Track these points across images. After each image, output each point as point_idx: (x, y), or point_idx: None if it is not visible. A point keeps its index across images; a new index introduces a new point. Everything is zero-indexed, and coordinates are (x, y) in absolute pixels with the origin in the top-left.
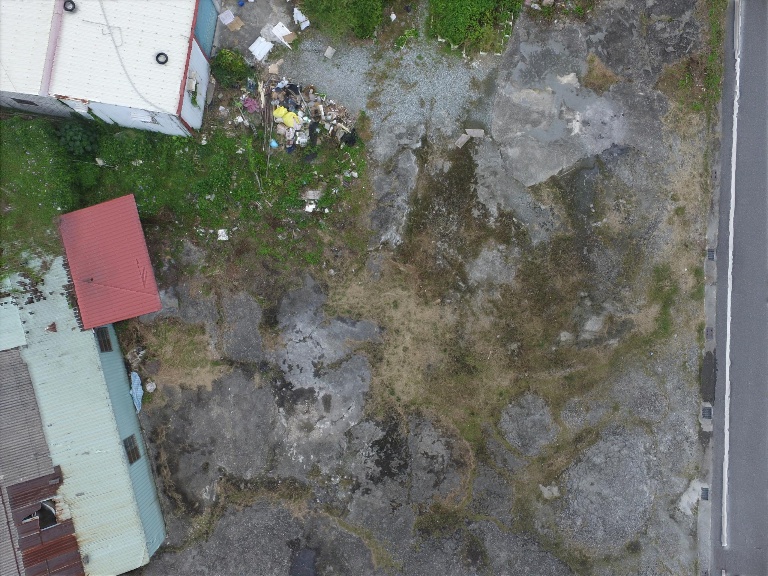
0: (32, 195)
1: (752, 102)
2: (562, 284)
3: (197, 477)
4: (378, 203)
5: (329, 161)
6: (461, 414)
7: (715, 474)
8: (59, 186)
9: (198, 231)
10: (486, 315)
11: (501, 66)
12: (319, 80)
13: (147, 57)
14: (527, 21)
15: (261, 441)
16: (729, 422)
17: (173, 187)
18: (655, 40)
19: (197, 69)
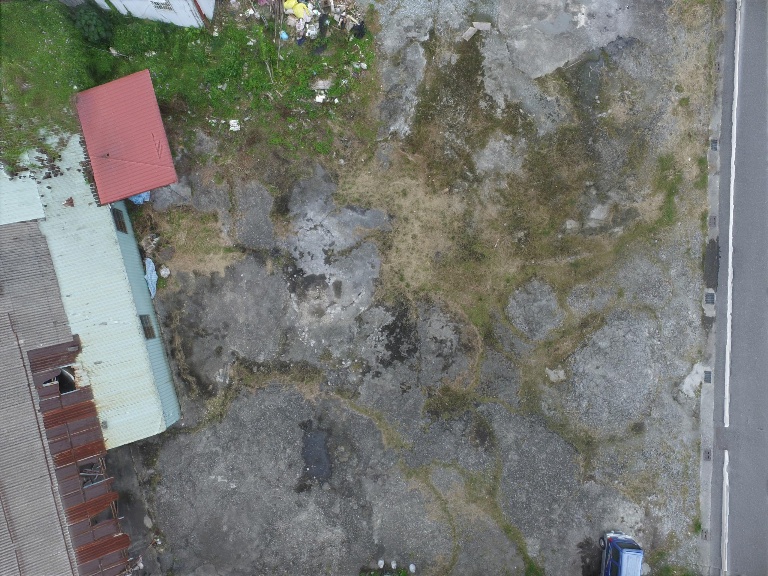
0: (49, 73)
1: None
2: (568, 173)
3: (211, 360)
4: (387, 94)
5: (339, 53)
6: (469, 300)
7: (718, 358)
8: (75, 65)
9: (210, 122)
10: (493, 204)
11: None
12: None
13: None
14: None
15: (273, 326)
16: (732, 307)
17: (185, 77)
18: None
19: None
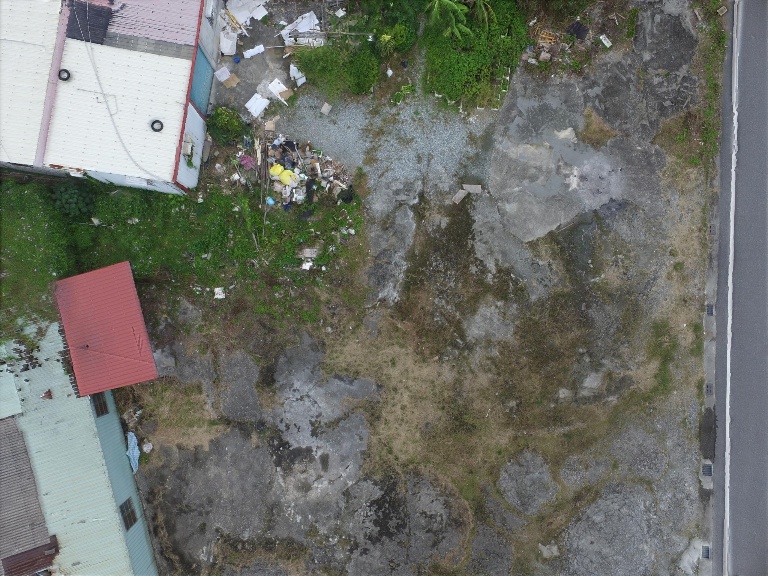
0: (27, 261)
1: (750, 156)
2: (560, 341)
3: (194, 538)
4: (375, 260)
5: (326, 218)
6: (460, 473)
7: (716, 532)
8: (54, 251)
9: (195, 289)
10: (484, 372)
11: (498, 121)
12: (315, 136)
13: (142, 125)
14: (524, 76)
15: (258, 501)
16: (729, 480)
17: (169, 246)
18: (652, 94)
19: (193, 130)
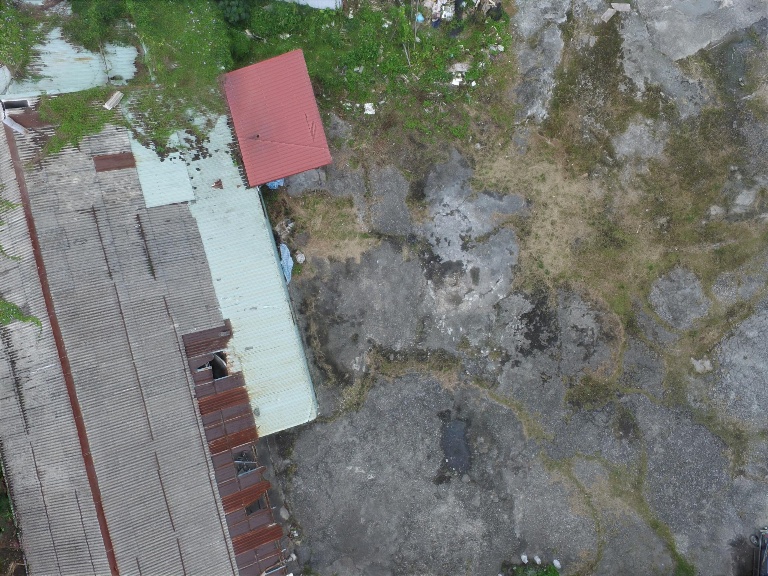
0: (197, 54)
1: None
2: (711, 158)
3: (347, 348)
4: (524, 77)
5: (475, 35)
6: (610, 287)
7: None
8: (223, 46)
9: (344, 105)
10: (634, 189)
11: None
12: None
13: None
14: None
15: (410, 313)
16: None
17: (321, 60)
18: None
19: None
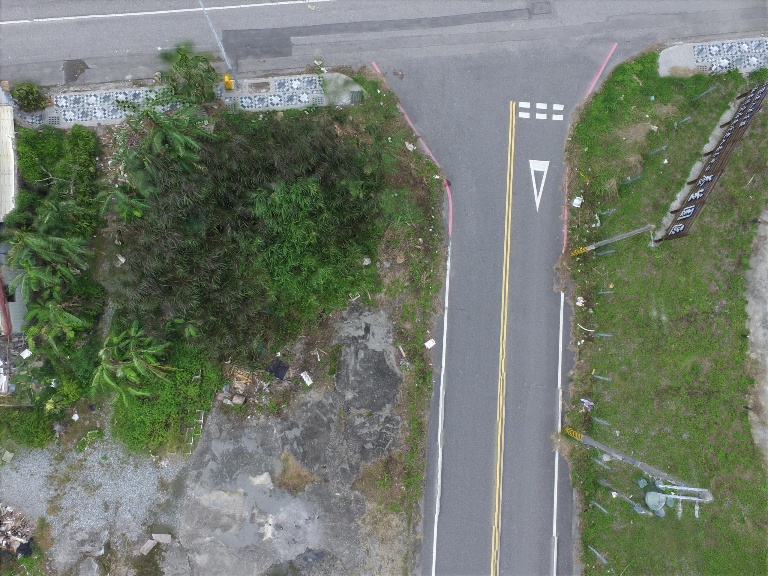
0: None
1: (455, 500)
2: None
3: None
4: None
5: (3, 575)
6: None
7: None
8: None
9: None
10: None
11: (191, 465)
12: None
13: None
14: (219, 416)
15: None
16: None
17: None
18: (353, 436)
19: None
